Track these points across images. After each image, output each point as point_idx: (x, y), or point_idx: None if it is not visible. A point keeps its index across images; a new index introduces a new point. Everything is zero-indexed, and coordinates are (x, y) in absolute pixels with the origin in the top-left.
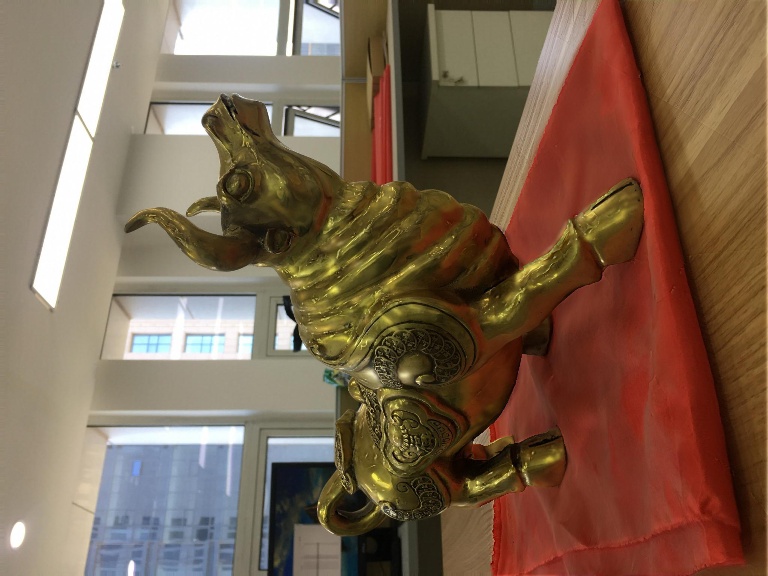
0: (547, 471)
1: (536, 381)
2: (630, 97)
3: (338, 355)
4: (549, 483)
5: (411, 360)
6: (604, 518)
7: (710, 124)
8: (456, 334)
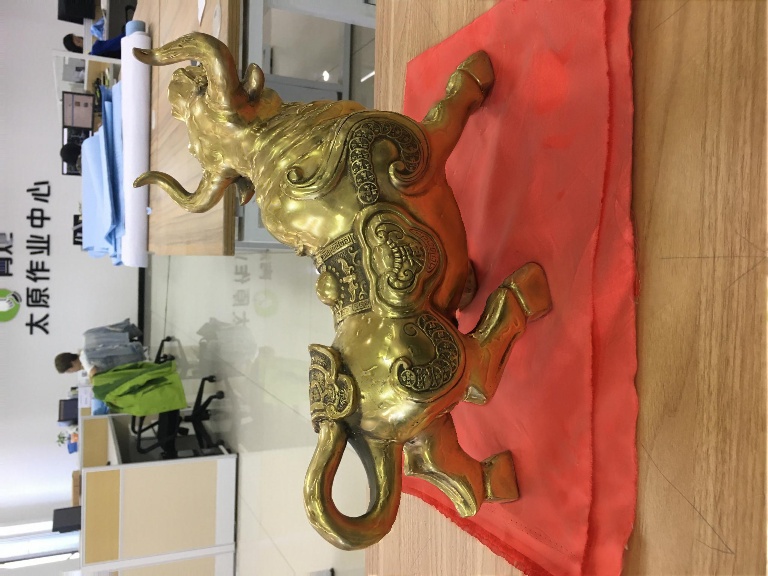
0: (533, 281)
1: (481, 307)
2: None
3: (315, 172)
4: (542, 300)
5: (381, 146)
6: (589, 185)
7: None
8: (408, 125)
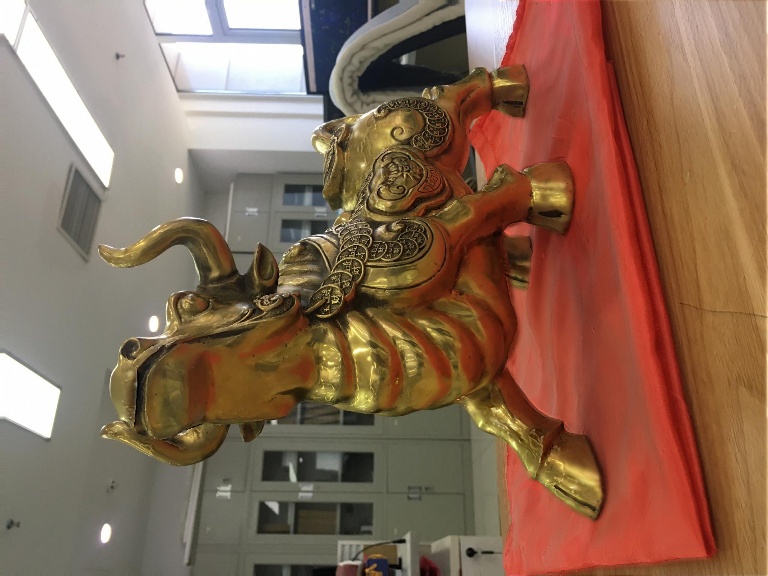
0: None
1: None
2: (620, 553)
3: None
4: None
5: None
6: (521, 373)
7: None
8: None
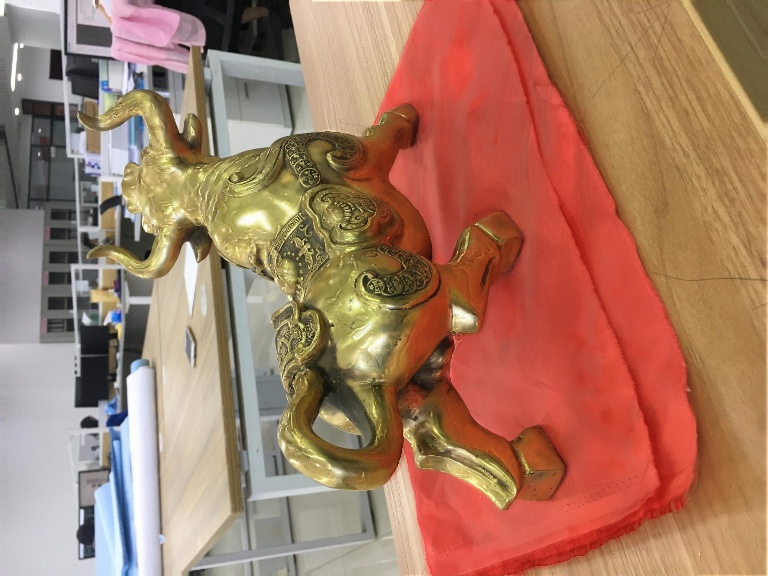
0: None
1: None
2: None
3: None
4: (510, 231)
5: (315, 144)
6: (514, 106)
7: (394, 51)
8: None
